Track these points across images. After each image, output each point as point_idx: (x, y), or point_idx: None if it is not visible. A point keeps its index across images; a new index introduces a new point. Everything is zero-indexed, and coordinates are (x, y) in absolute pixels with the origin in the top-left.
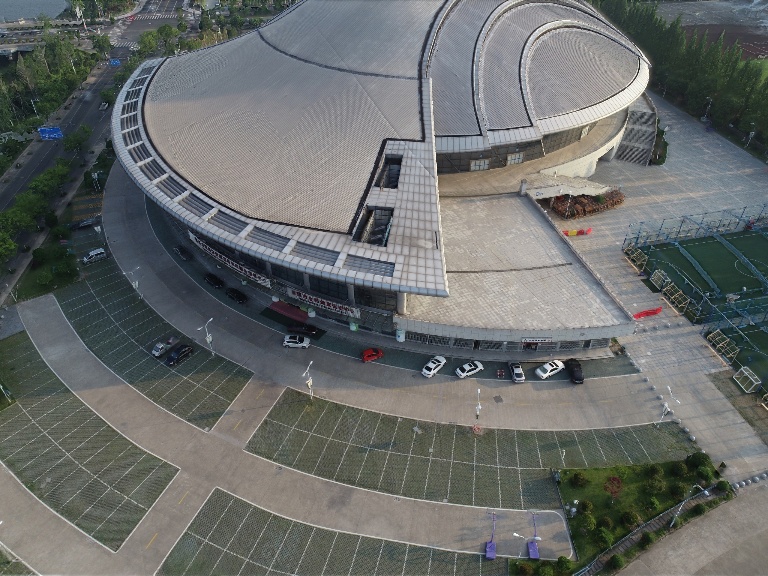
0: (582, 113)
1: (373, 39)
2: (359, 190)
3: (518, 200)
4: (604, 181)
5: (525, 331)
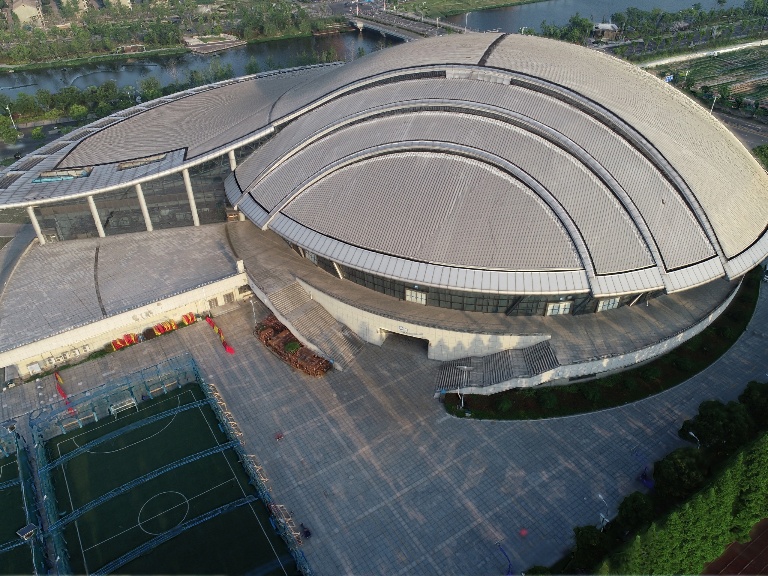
0: (320, 239)
1: (318, 83)
2: (115, 160)
3: (229, 272)
4: (366, 357)
5: (1, 297)
